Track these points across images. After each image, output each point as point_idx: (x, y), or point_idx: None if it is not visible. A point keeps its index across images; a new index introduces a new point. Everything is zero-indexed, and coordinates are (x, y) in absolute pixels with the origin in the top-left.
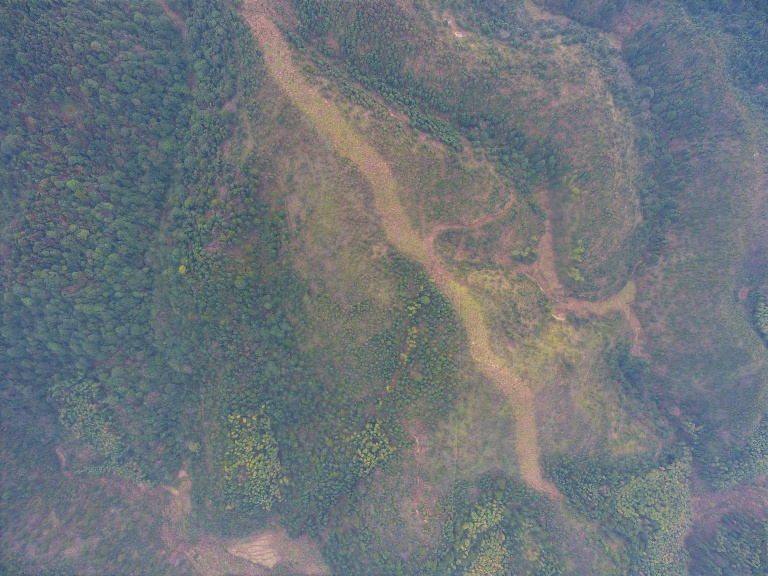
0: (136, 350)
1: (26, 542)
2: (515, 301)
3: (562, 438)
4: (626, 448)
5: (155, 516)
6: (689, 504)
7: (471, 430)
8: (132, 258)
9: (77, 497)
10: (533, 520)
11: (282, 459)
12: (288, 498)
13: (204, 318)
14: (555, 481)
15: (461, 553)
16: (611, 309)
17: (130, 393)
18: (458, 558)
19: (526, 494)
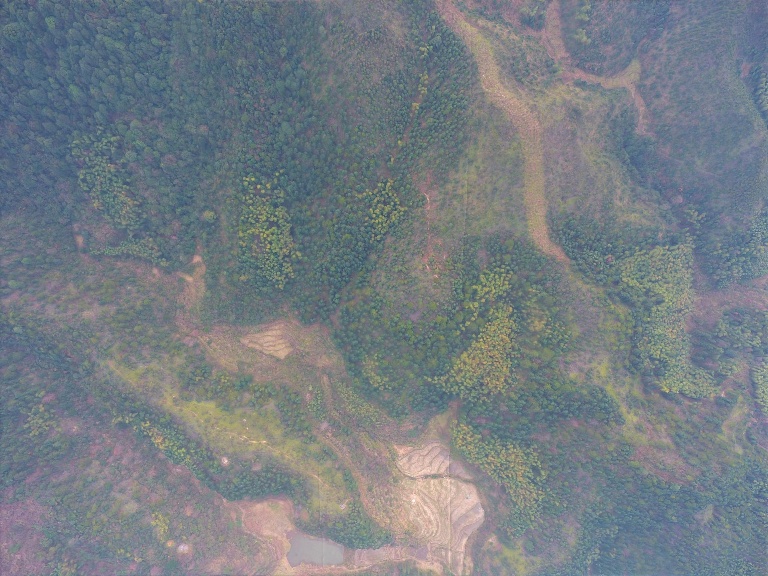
0: (154, 106)
1: (45, 303)
2: (524, 51)
3: (569, 195)
4: (631, 217)
5: (170, 299)
6: (692, 290)
7: (481, 171)
8: (151, 0)
9: (94, 274)
10: (540, 286)
11: (295, 237)
12: (300, 275)
13: (222, 53)
14: (562, 242)
15: (470, 313)
16: (616, 86)
17: (148, 149)
18: (467, 320)
19: (533, 255)
